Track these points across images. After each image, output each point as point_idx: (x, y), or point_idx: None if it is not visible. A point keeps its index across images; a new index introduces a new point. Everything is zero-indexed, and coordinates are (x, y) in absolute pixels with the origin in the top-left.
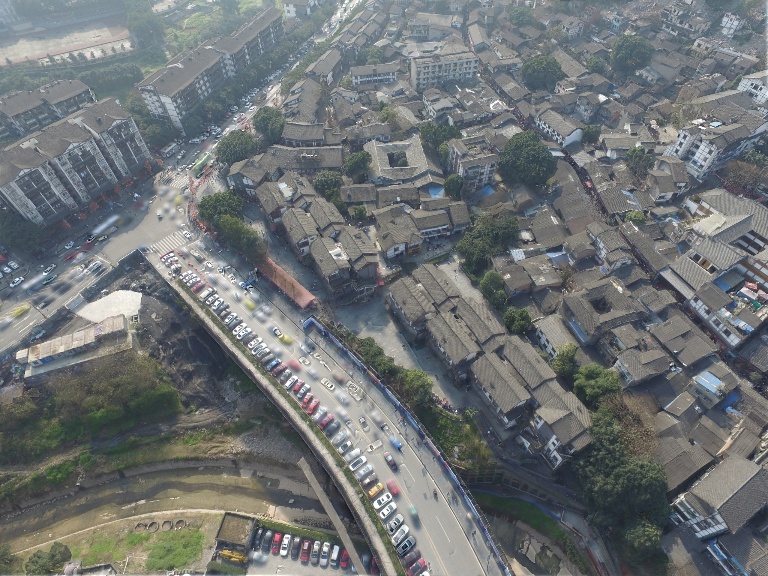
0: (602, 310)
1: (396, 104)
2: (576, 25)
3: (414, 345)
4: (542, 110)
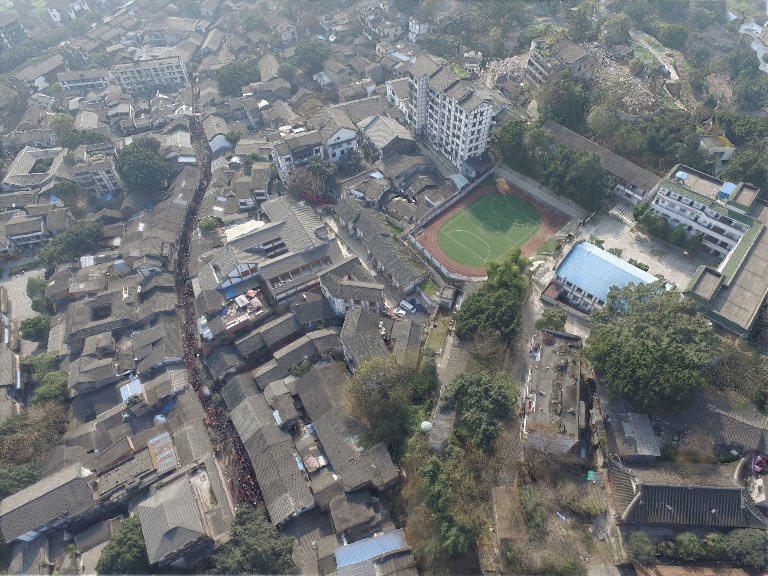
0: None
1: (82, 110)
2: (286, 30)
3: None
4: (206, 115)
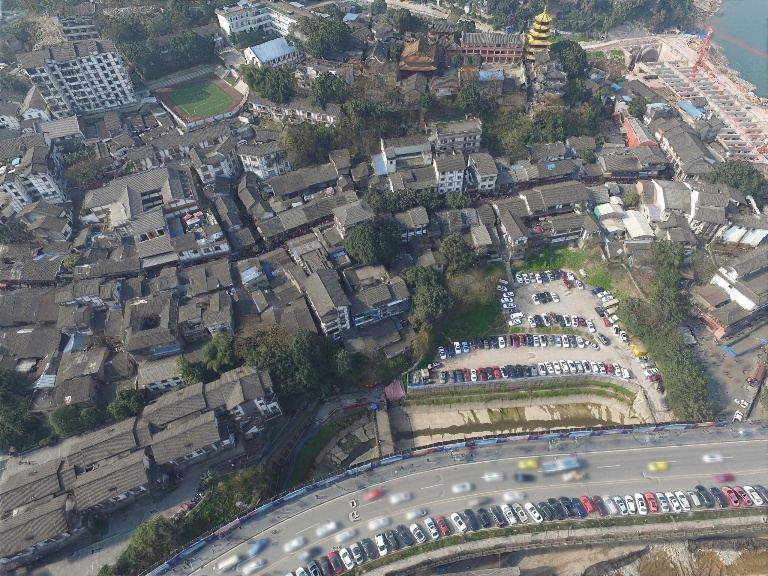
0: (155, 324)
1: None
2: None
3: (99, 536)
4: None
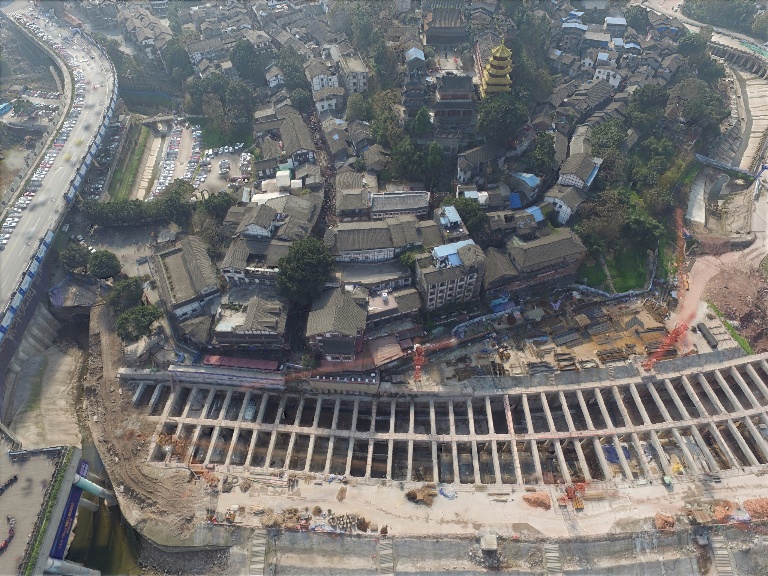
0: None
1: None
2: None
3: (127, 41)
4: None
